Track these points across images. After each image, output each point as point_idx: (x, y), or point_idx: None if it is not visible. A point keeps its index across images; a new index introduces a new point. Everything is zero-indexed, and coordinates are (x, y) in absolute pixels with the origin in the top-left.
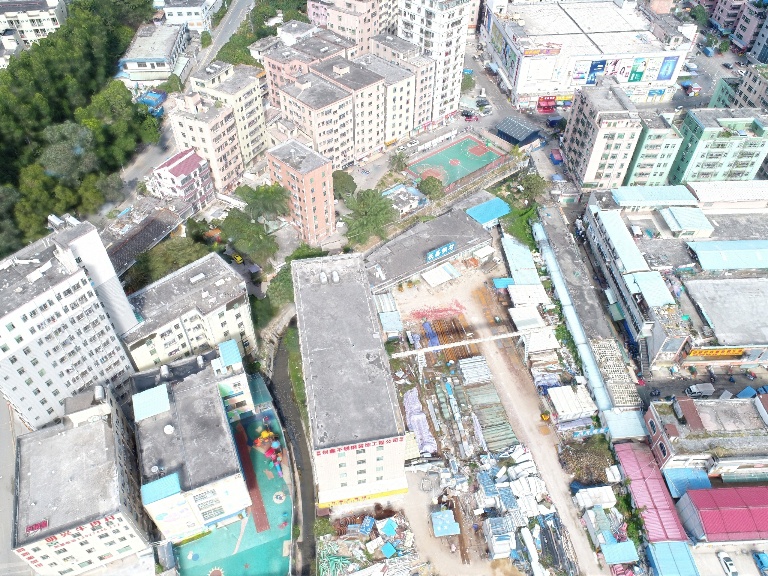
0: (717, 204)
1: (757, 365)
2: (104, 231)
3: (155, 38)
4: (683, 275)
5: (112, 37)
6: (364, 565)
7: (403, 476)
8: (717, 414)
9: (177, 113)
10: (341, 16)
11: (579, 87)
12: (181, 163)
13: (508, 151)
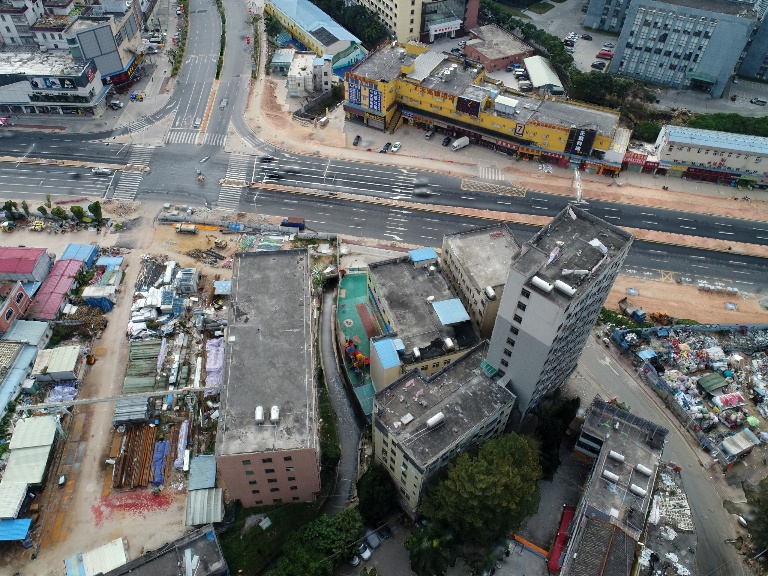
0: None
1: None
2: None
3: None
4: None
5: None
6: None
7: None
8: None
9: None
10: None
11: None
12: None
13: None
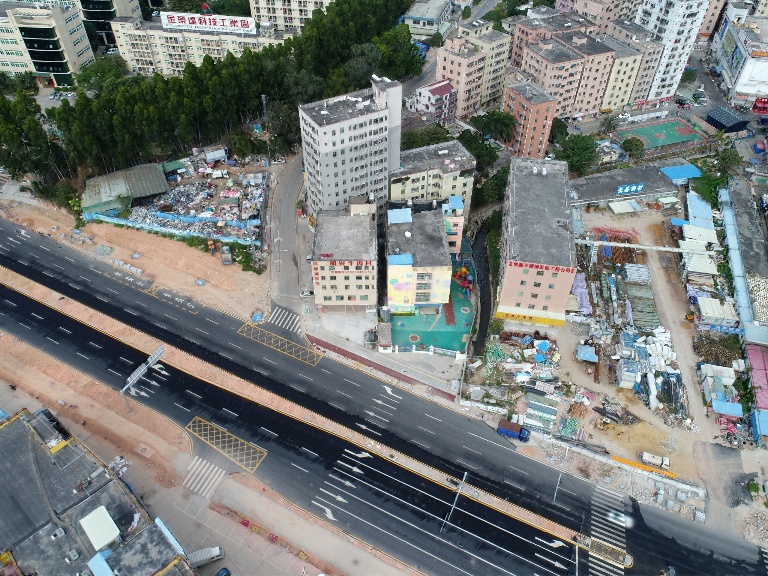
0: None
1: None
2: None
3: (430, 5)
4: None
5: None
6: (519, 361)
7: (563, 313)
8: None
9: (444, 51)
10: (587, 3)
11: None
12: (438, 87)
13: (713, 136)
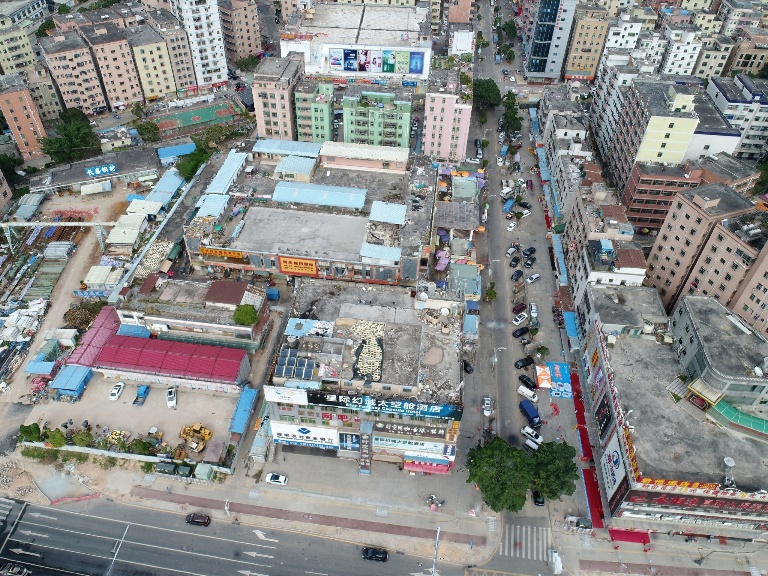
0: (338, 160)
1: (267, 273)
2: None
3: (11, 3)
4: (256, 203)
5: None
6: None
7: None
8: (180, 291)
9: None
10: None
11: (339, 72)
12: None
13: None
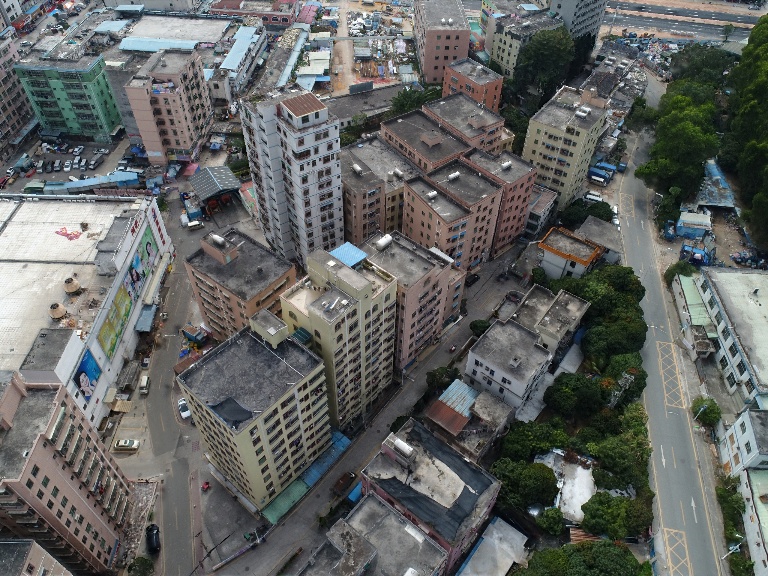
0: None
1: None
2: (626, 112)
3: None
4: None
5: None
6: None
7: None
8: None
9: None
10: None
11: None
12: None
13: None
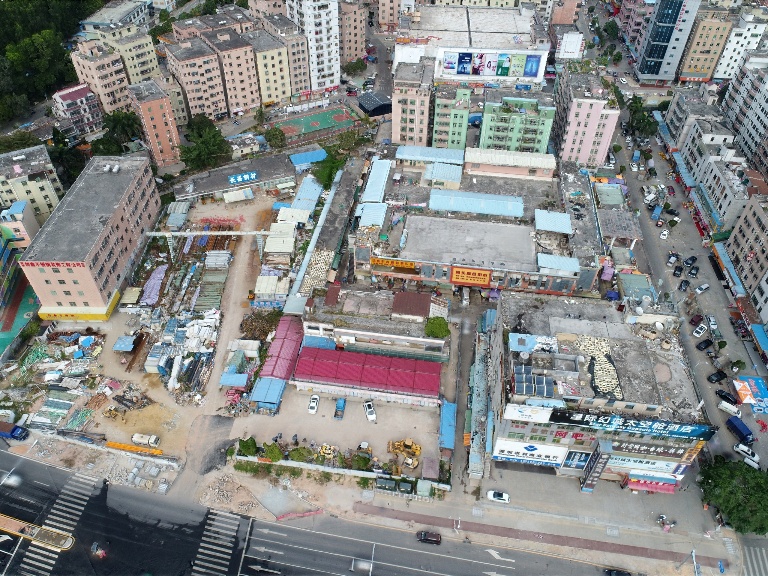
0: (483, 166)
1: (436, 283)
2: (4, 135)
3: (117, 9)
4: (412, 211)
5: (81, 5)
6: (57, 360)
7: (106, 307)
8: (361, 302)
9: (78, 55)
10: (256, 0)
11: (451, 76)
12: (72, 92)
13: None
